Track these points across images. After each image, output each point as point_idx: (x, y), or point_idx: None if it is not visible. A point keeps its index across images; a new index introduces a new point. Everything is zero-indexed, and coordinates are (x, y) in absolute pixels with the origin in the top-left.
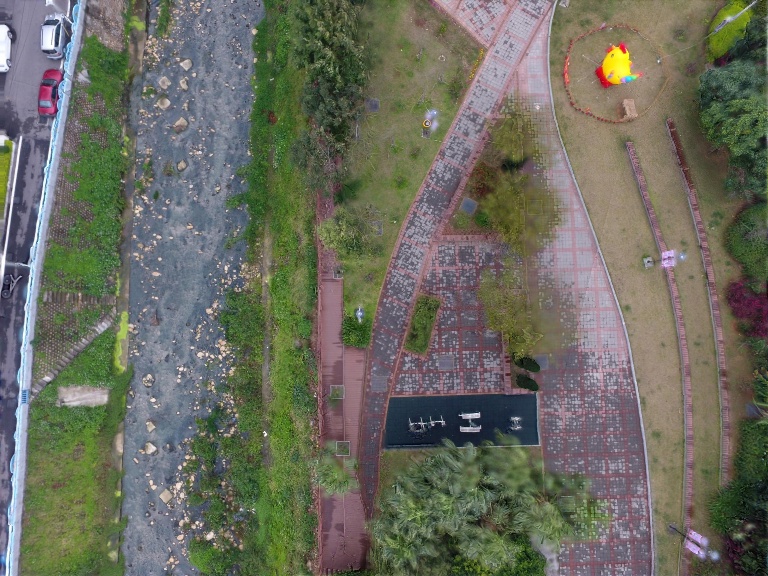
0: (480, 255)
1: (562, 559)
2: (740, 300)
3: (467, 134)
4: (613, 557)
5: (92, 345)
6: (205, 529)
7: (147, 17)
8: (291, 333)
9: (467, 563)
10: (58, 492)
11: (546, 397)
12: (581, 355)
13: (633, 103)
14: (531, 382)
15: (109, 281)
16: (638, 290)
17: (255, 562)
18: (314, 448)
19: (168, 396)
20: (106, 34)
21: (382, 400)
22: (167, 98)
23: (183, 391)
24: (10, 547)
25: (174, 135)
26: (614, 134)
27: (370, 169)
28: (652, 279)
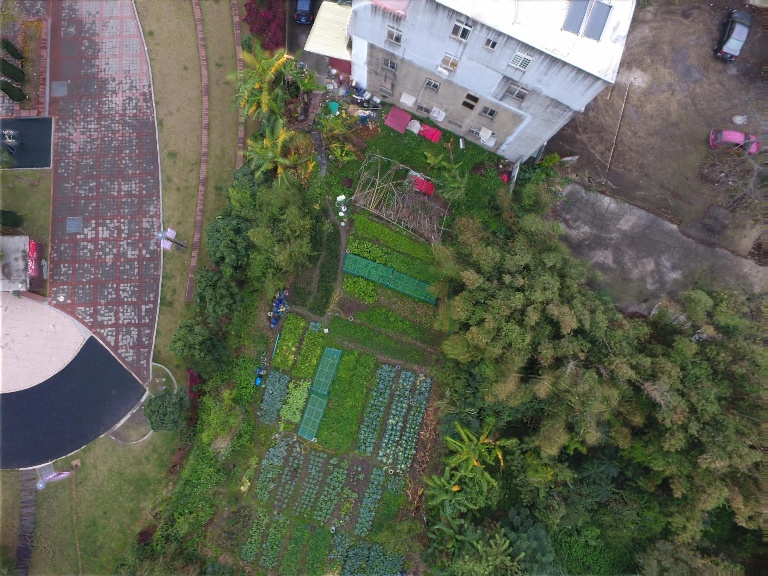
0: None
1: (64, 279)
2: None
3: None
4: (119, 276)
5: None
6: None
7: None
8: None
9: None
10: None
11: (61, 122)
12: (101, 81)
13: None
14: None
15: None
16: (163, 16)
17: None
18: None
19: None
20: None
21: None
22: None
23: None
24: None
25: None
26: None
27: None
28: (178, 5)
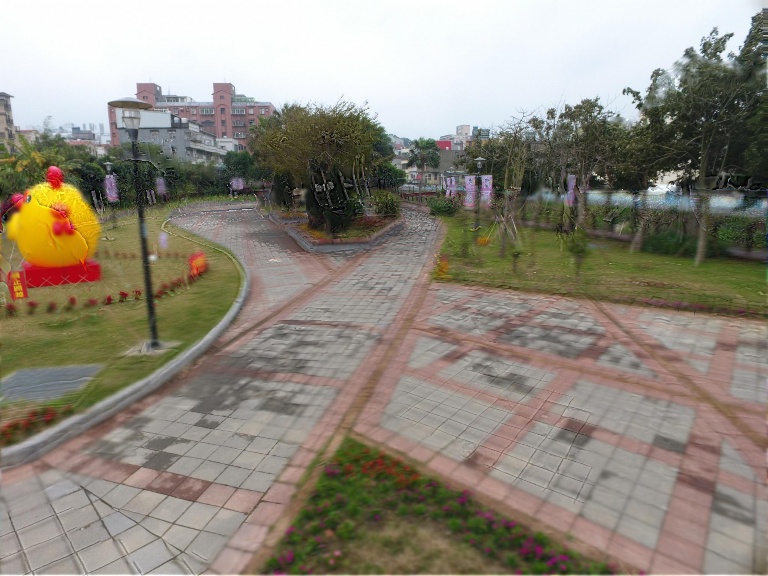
0: None
1: None
2: None
3: None
4: None
5: None
6: None
7: None
8: None
9: None
10: None
11: None
12: None
13: None
14: None
15: None
16: None
17: None
18: None
19: None
20: None
21: None
22: None
23: None
24: None
25: None
26: None
27: None
28: (110, 237)
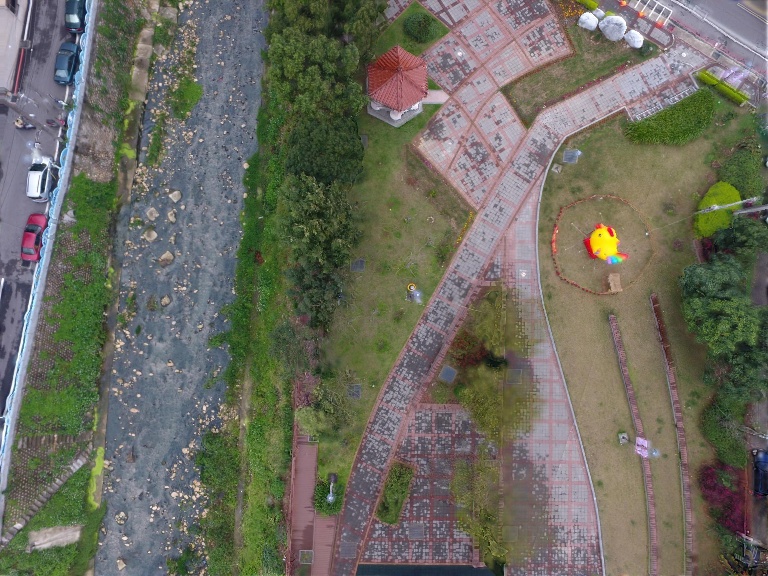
0: (457, 423)
1: None
2: (710, 486)
3: (451, 299)
4: None
5: (66, 485)
6: None
7: (138, 144)
8: (264, 489)
9: None
10: None
11: (513, 569)
12: (550, 528)
13: (618, 278)
14: (497, 570)
15: (86, 417)
16: (611, 466)
17: None
18: None
19: (140, 534)
20: (95, 168)
21: (350, 566)
22: (154, 230)
23: (155, 530)
24: None
25: (159, 269)
26: (598, 306)
27: (352, 332)
28: (626, 455)
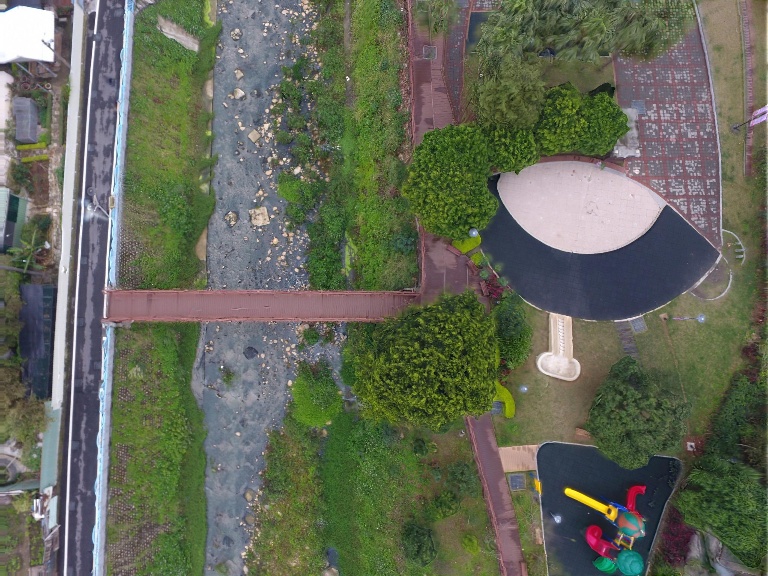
0: None
1: None
2: None
3: None
4: (683, 154)
5: None
6: (292, 163)
7: None
8: None
9: (559, 101)
10: (158, 107)
11: None
12: None
13: None
14: None
15: None
16: None
17: (342, 185)
18: (402, 54)
19: (255, 48)
20: None
21: (464, 14)
22: None
23: (269, 43)
24: (117, 138)
25: None
26: None
27: None
28: None
